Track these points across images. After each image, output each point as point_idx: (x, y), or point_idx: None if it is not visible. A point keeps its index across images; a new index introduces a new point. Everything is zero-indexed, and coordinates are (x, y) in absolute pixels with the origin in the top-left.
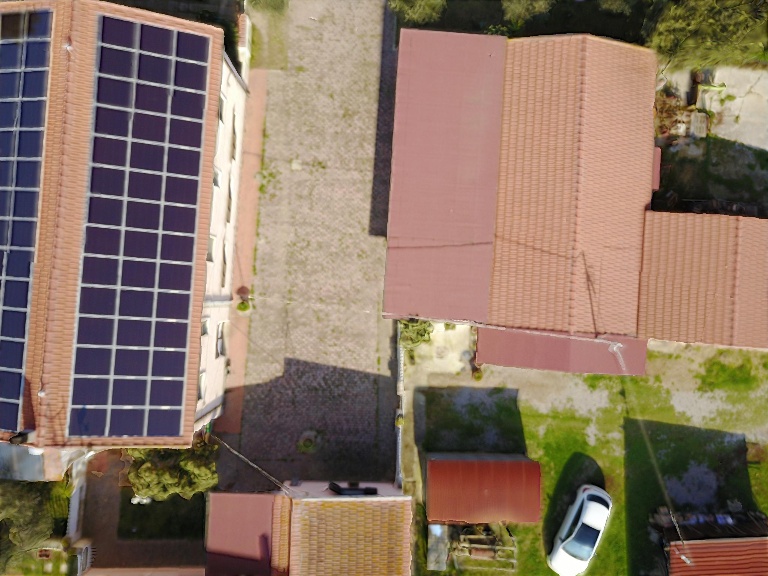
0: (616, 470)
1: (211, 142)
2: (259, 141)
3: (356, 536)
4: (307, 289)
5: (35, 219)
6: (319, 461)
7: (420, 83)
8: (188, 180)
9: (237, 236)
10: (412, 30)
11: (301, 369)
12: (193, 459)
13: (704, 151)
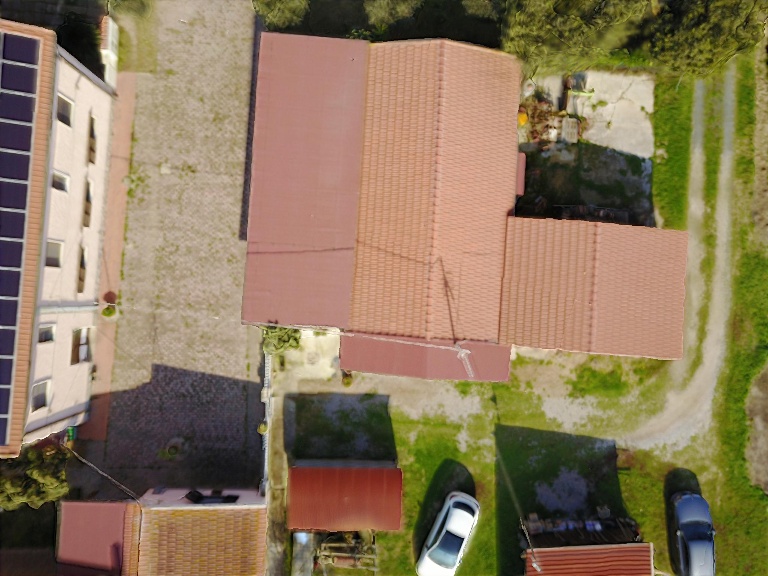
0: (487, 477)
1: (42, 146)
2: (127, 144)
3: (208, 545)
4: (176, 294)
5: None
6: (186, 469)
7: (281, 87)
8: (16, 184)
9: (104, 241)
10: (273, 34)
11: (169, 375)
12: (40, 468)
13: (576, 157)
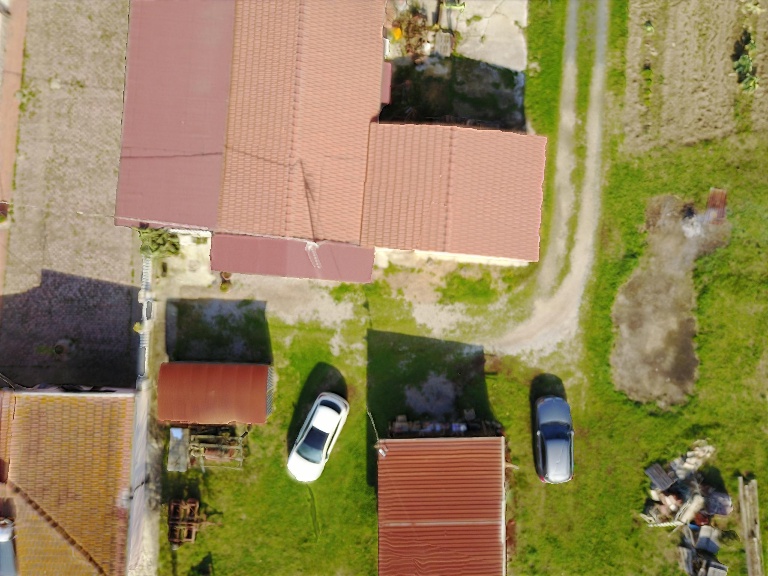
0: (359, 380)
1: None
2: (19, 60)
3: (77, 429)
4: (65, 203)
5: None
6: (73, 368)
7: None
8: None
9: None
10: None
11: (58, 280)
12: None
13: (449, 70)
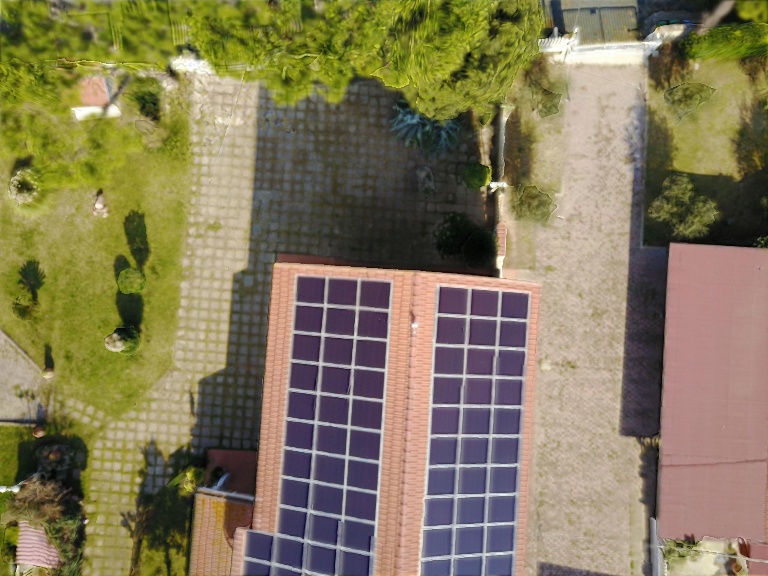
0: None
1: (529, 397)
2: None
3: None
4: (558, 491)
5: (374, 492)
6: None
7: (689, 297)
8: (511, 439)
9: None
10: (681, 244)
11: (553, 573)
12: None
13: None
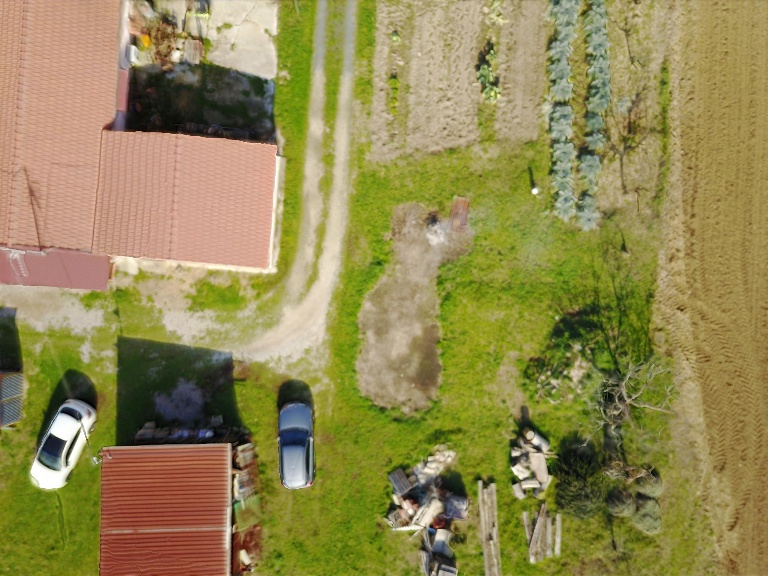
0: (109, 387)
1: None
2: None
3: None
4: None
5: None
6: None
7: None
8: None
9: None
10: None
11: None
12: None
13: (199, 78)
